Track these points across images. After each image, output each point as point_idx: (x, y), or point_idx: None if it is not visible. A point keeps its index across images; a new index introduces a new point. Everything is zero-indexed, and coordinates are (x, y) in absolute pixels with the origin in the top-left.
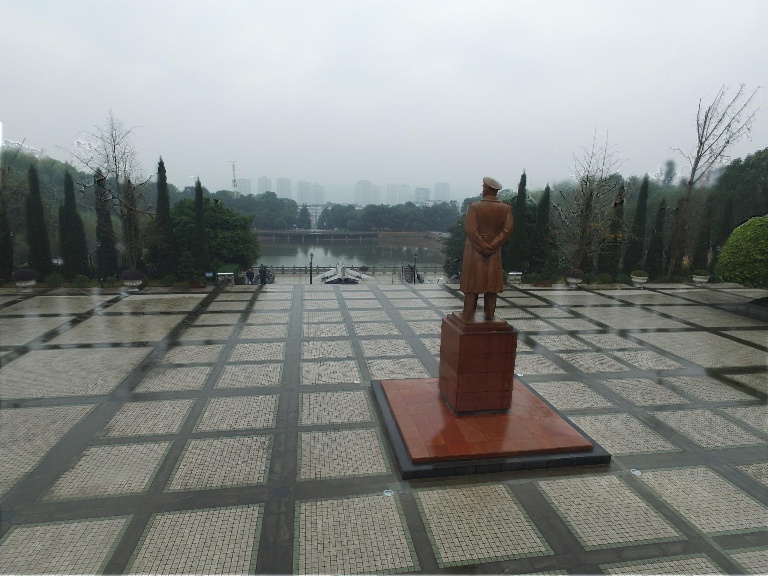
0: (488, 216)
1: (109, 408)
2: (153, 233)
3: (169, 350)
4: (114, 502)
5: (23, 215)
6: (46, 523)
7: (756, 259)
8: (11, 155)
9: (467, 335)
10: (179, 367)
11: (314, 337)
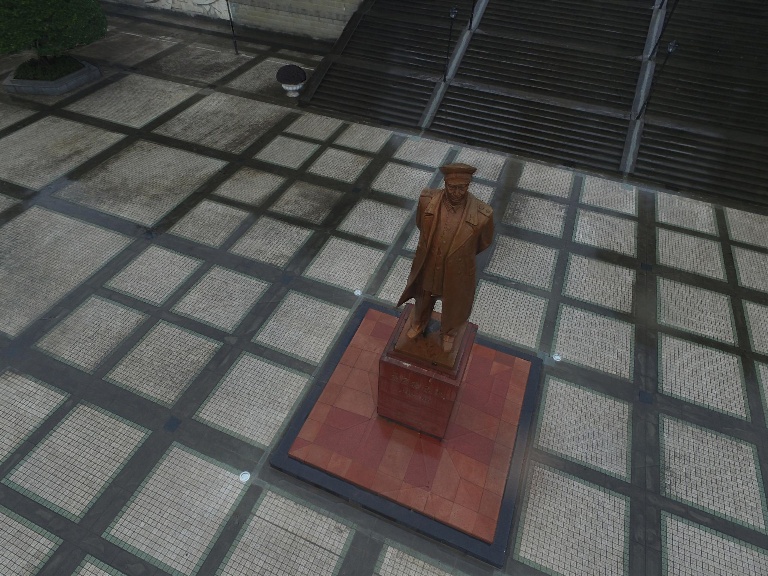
0: None
1: None
2: None
3: None
4: None
5: None
6: None
7: None
8: None
9: None
10: None
11: None
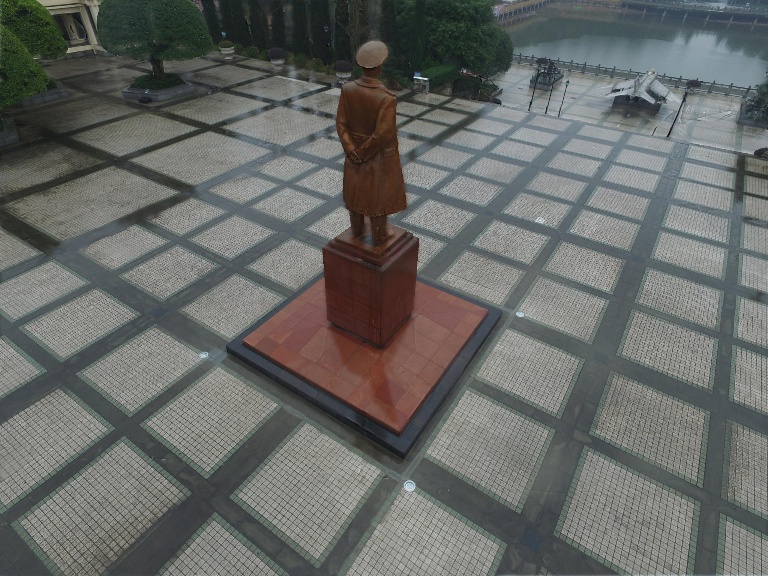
0: (355, 108)
1: (180, 198)
2: (378, 19)
3: (276, 158)
4: (95, 269)
5: None
6: (62, 265)
7: None
8: None
9: (328, 252)
10: (259, 177)
11: None
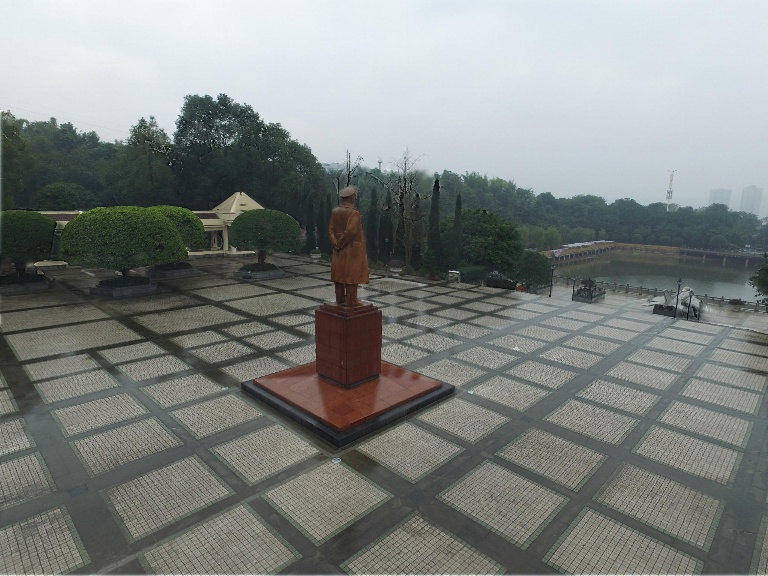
0: (338, 219)
1: (247, 321)
2: (427, 235)
3: None
4: (175, 347)
5: (366, 219)
6: None
7: None
8: (367, 181)
9: (318, 312)
10: (307, 315)
11: (409, 322)
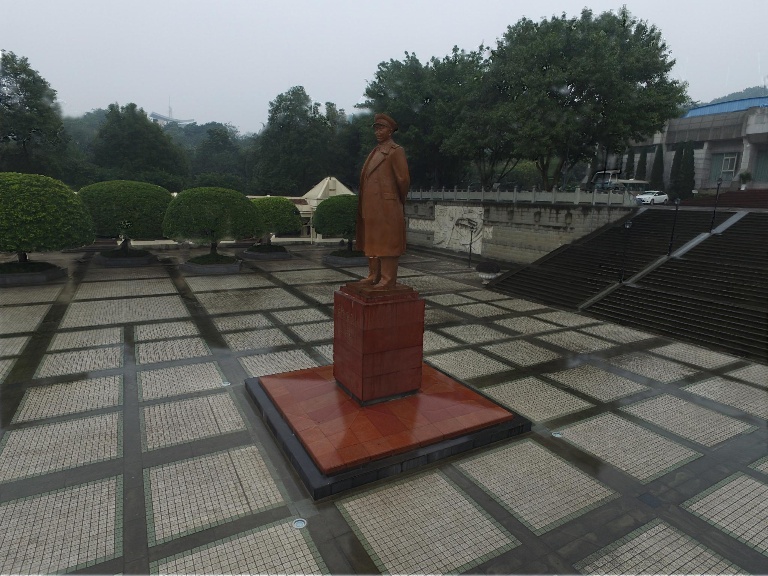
0: None
1: None
2: None
3: None
4: None
5: None
6: None
7: (24, 221)
8: None
9: None
10: None
11: None
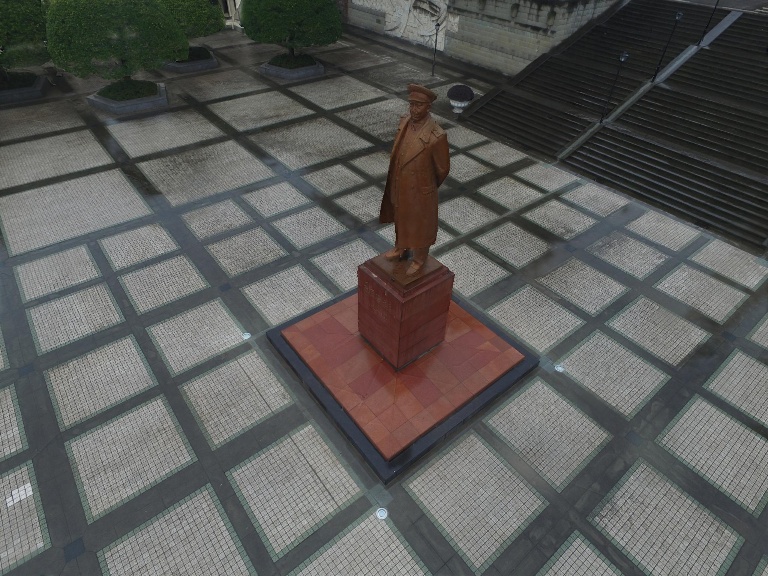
0: None
1: None
2: None
3: None
4: None
5: None
6: None
7: None
8: None
9: None
10: None
11: None
